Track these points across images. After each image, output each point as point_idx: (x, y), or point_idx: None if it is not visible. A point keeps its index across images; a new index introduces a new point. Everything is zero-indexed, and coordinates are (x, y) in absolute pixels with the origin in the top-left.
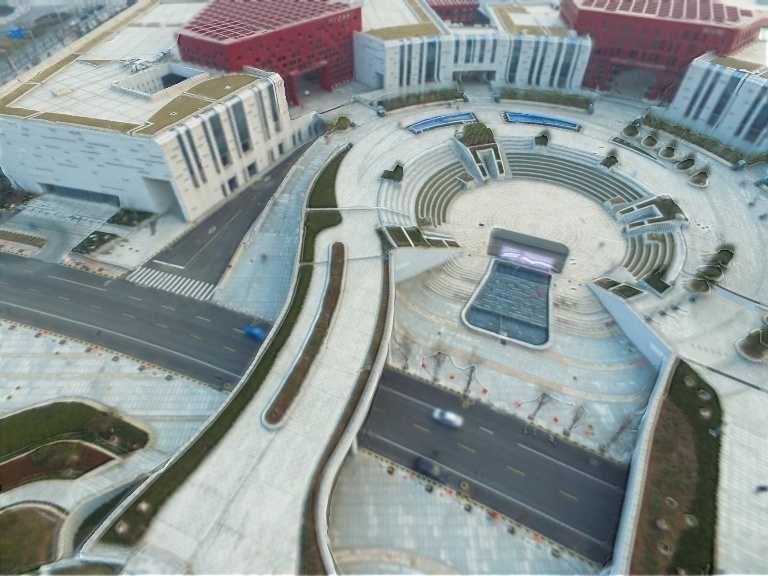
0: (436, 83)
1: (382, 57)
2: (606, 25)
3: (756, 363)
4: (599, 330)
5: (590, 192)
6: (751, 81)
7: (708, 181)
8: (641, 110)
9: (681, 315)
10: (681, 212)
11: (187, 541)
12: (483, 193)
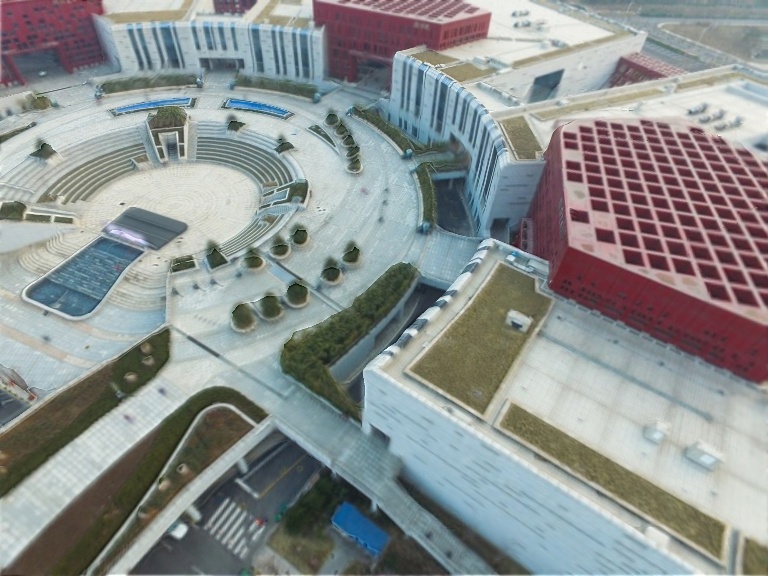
0: (179, 69)
1: (112, 40)
2: (339, 17)
3: (238, 333)
4: (150, 303)
5: (257, 176)
6: (429, 74)
7: (362, 168)
8: (370, 101)
9: (214, 289)
10: (303, 195)
11: None
12: (153, 175)
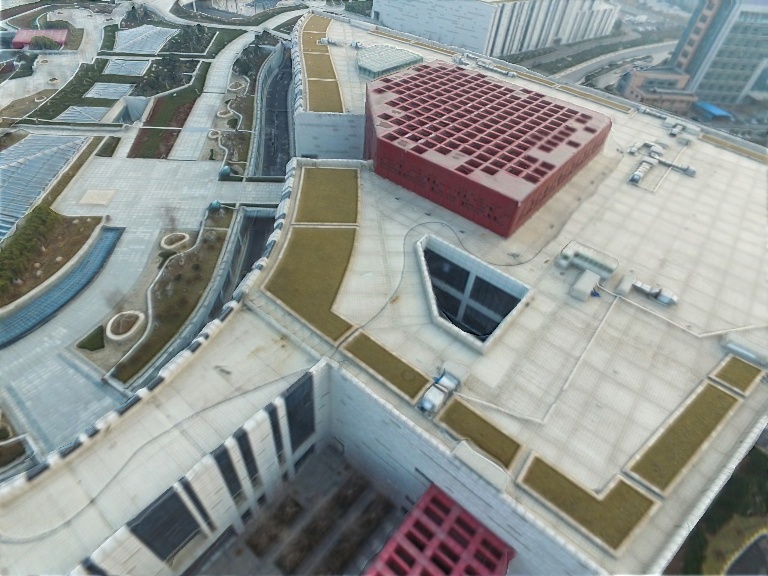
0: None
1: None
2: None
3: None
4: None
5: None
6: None
7: None
8: None
9: None
10: None
11: (144, 2)
12: None
